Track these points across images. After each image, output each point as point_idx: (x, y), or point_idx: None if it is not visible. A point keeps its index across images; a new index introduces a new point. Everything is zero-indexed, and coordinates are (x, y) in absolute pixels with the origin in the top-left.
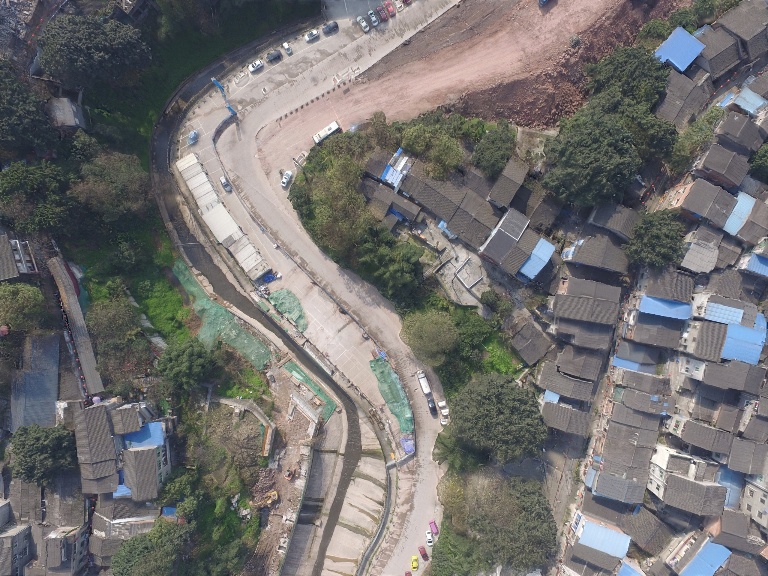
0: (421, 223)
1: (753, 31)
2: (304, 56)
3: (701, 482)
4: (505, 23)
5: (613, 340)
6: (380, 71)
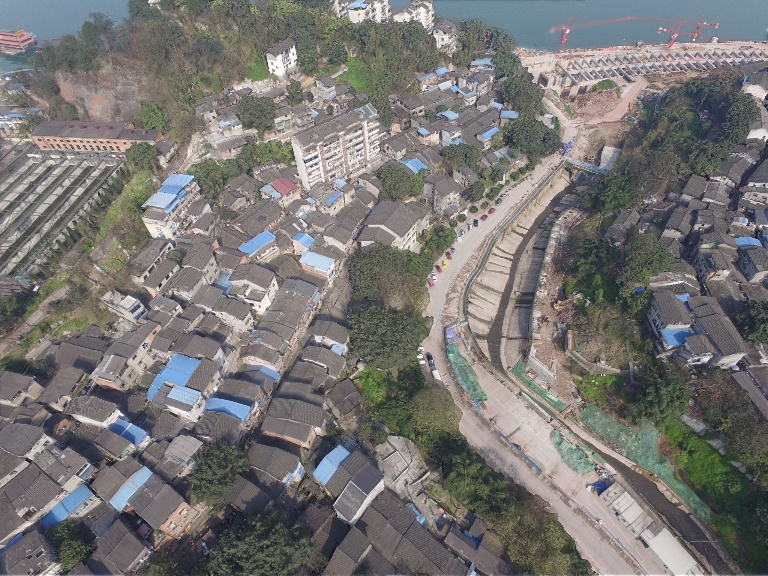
0: None
1: None
2: None
3: (245, 284)
4: None
5: (273, 396)
6: None
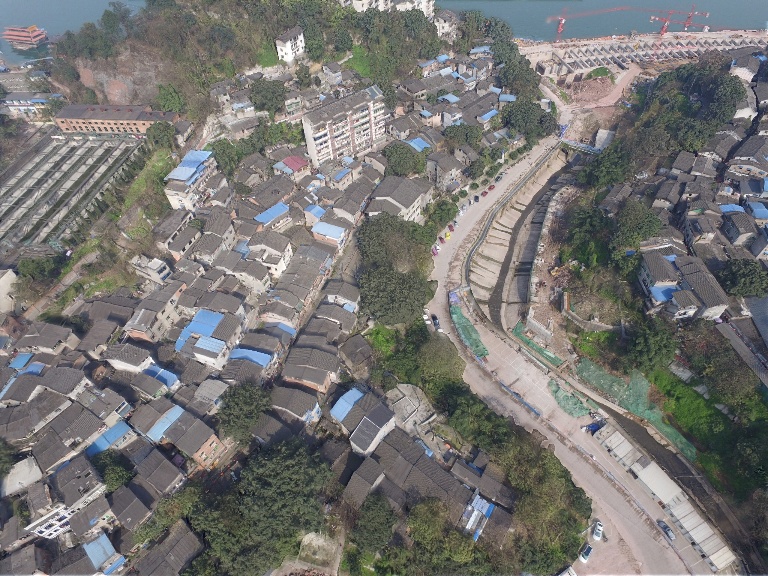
0: None
1: None
2: None
3: (262, 248)
4: None
5: None
6: None
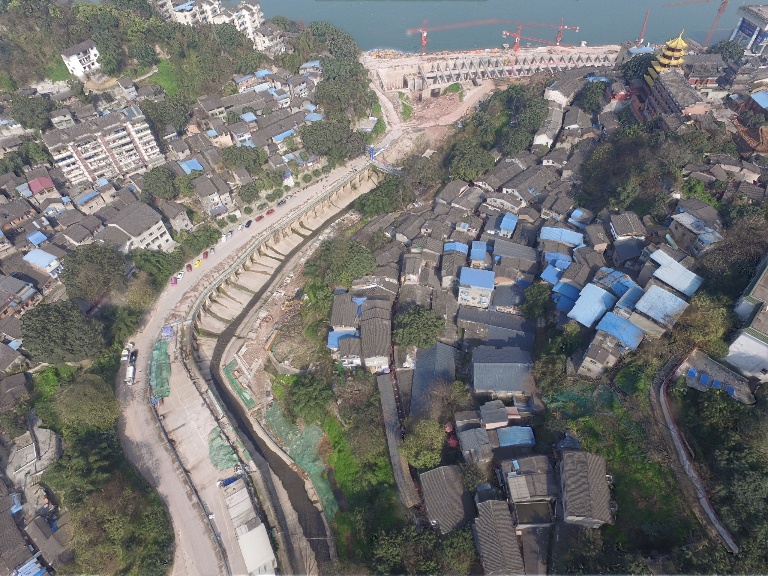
0: None
1: None
2: None
3: None
4: None
5: None
6: None
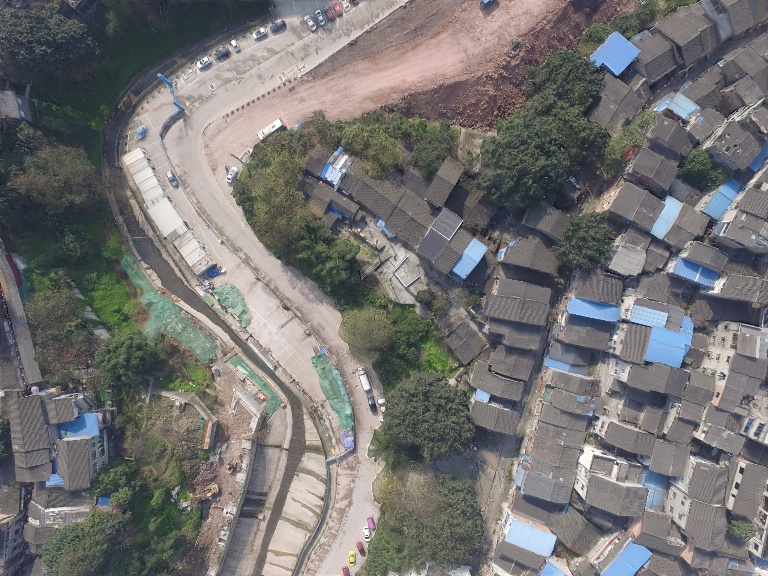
0: (361, 221)
1: (688, 37)
2: (252, 54)
3: (623, 483)
4: (447, 25)
5: (547, 341)
6: (325, 70)
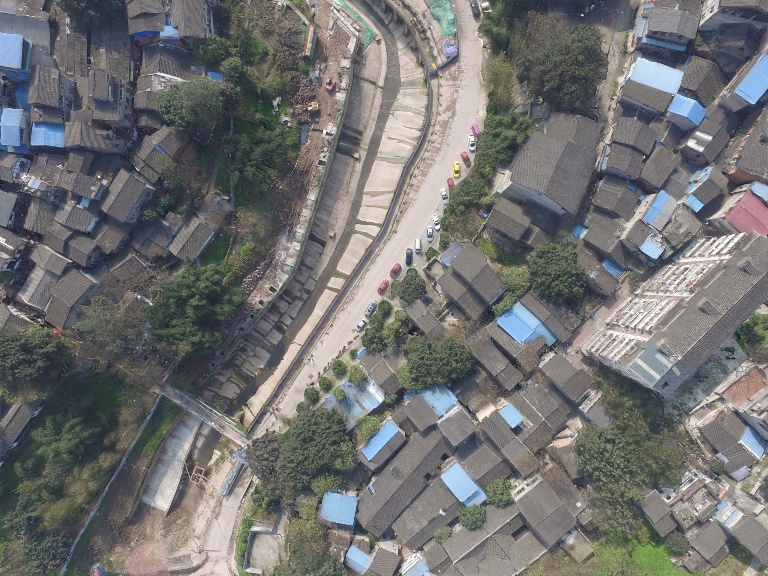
0: None
1: None
2: None
3: None
4: None
5: None
6: None
